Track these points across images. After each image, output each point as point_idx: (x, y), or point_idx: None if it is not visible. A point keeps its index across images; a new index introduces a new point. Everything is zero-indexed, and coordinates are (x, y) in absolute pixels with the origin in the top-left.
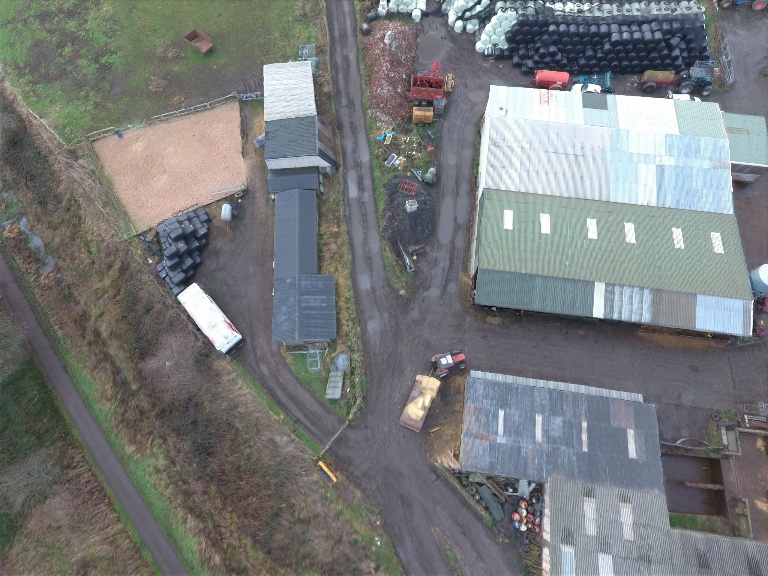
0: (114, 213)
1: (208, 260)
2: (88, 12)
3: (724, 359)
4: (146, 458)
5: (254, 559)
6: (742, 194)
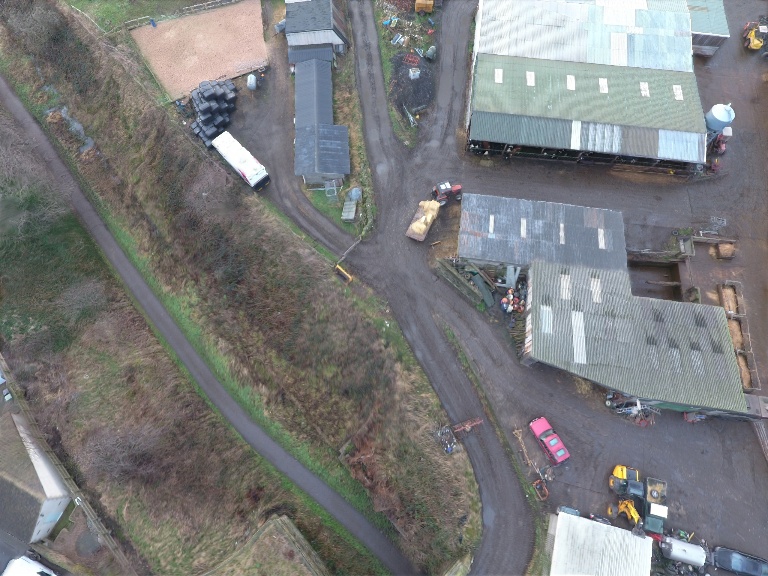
0: (151, 86)
1: (236, 121)
2: None
3: (684, 191)
4: (181, 296)
5: (278, 367)
6: (703, 65)
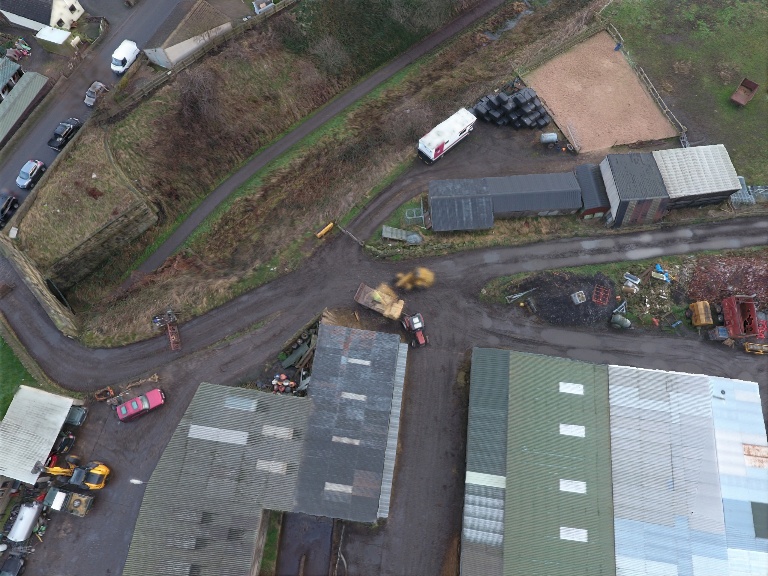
0: None
1: (501, 131)
2: (756, 0)
3: None
4: (344, 126)
5: (272, 202)
6: None
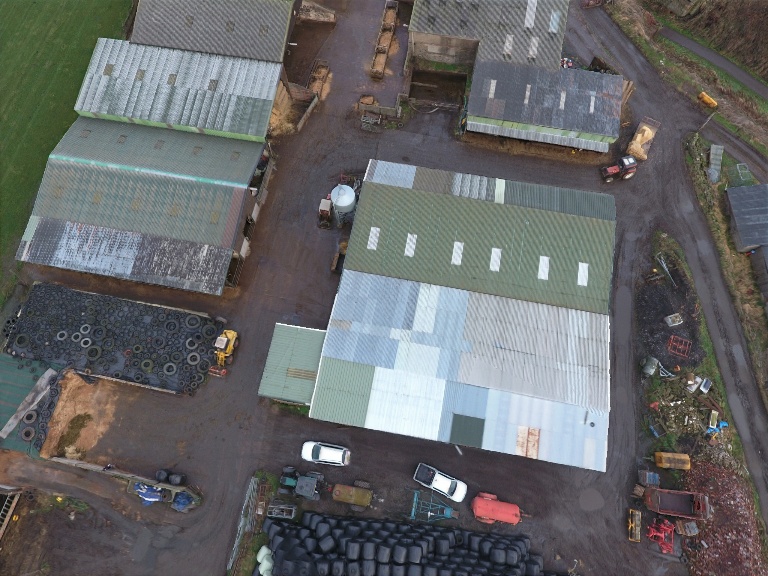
0: None
1: None
2: None
3: None
4: None
5: None
6: (302, 317)
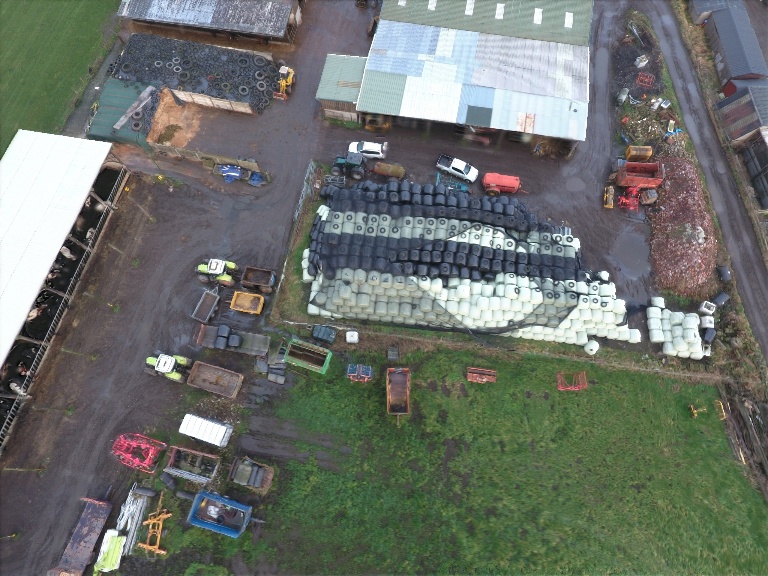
0: None
1: None
2: None
3: None
4: None
5: None
6: None
